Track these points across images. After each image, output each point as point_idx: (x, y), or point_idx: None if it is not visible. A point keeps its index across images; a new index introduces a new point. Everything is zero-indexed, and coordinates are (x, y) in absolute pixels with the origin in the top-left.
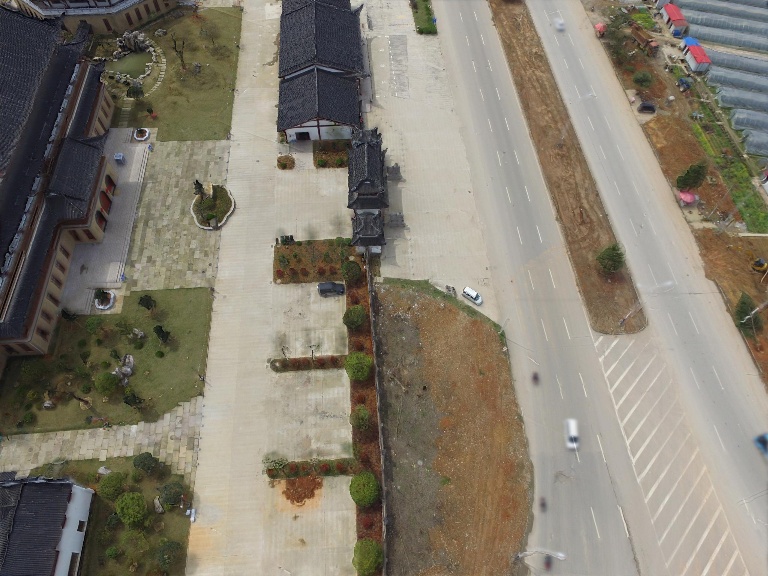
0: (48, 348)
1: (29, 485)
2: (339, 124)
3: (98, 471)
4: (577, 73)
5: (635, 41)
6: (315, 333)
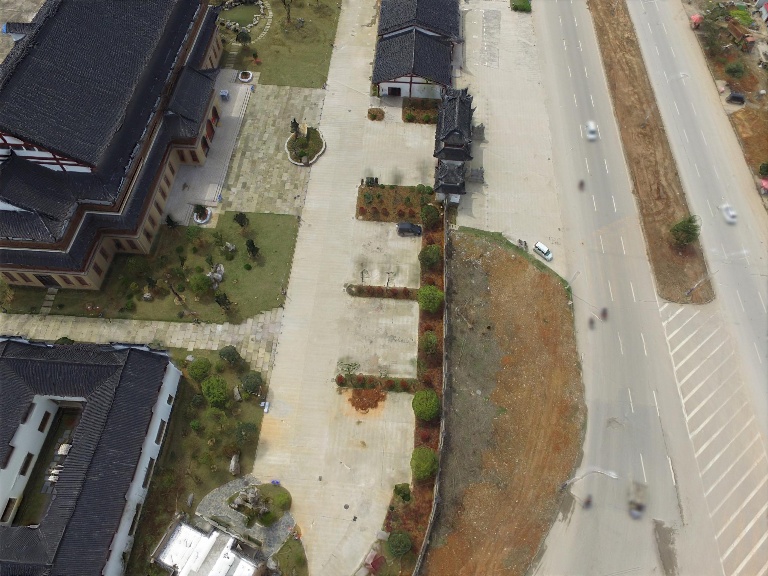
0: (150, 249)
1: (135, 351)
2: (431, 83)
3: (186, 358)
4: (667, 60)
5: (730, 35)
6: (390, 267)
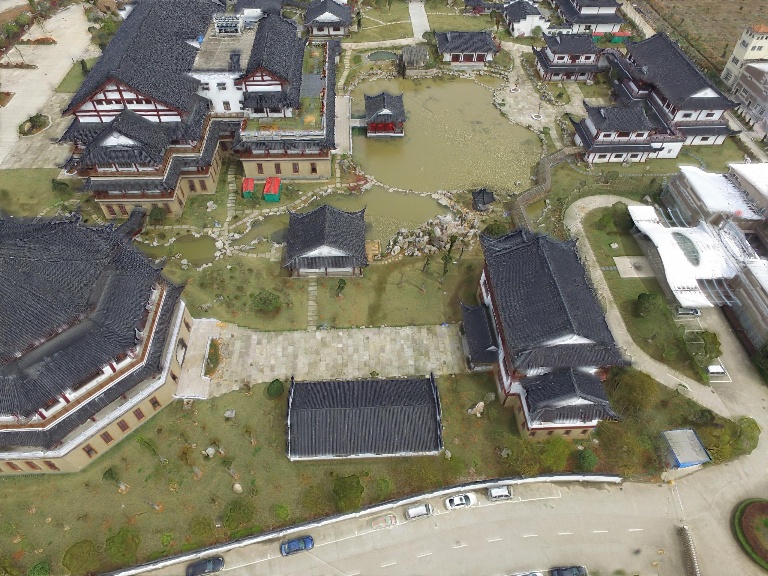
0: None
1: None
2: None
3: None
4: None
5: None
6: (6, 75)
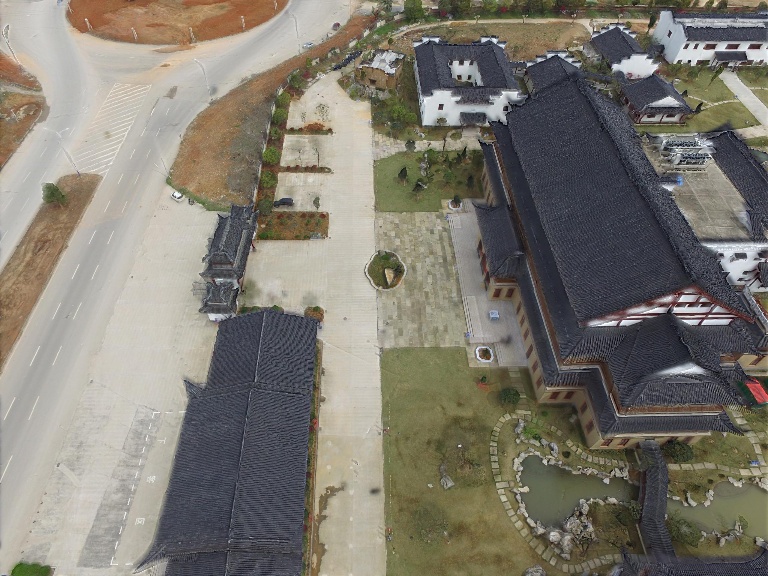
0: None
1: None
2: None
3: None
4: None
5: None
6: (300, 184)
